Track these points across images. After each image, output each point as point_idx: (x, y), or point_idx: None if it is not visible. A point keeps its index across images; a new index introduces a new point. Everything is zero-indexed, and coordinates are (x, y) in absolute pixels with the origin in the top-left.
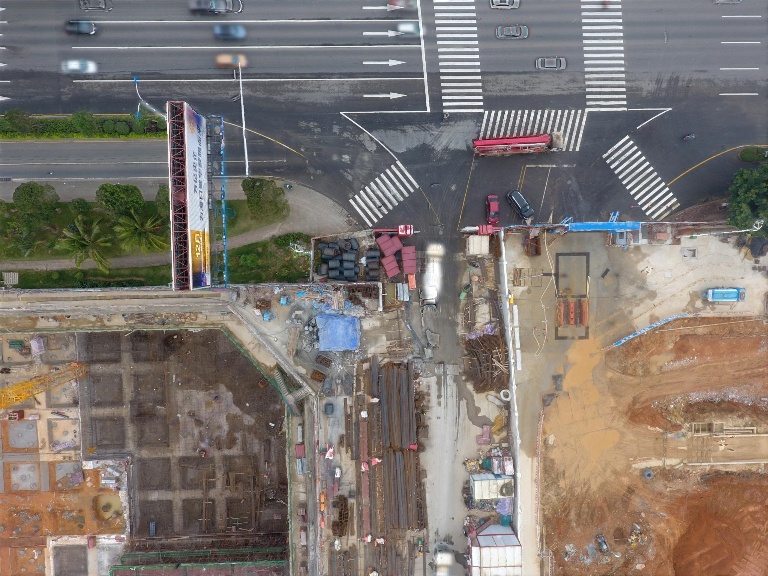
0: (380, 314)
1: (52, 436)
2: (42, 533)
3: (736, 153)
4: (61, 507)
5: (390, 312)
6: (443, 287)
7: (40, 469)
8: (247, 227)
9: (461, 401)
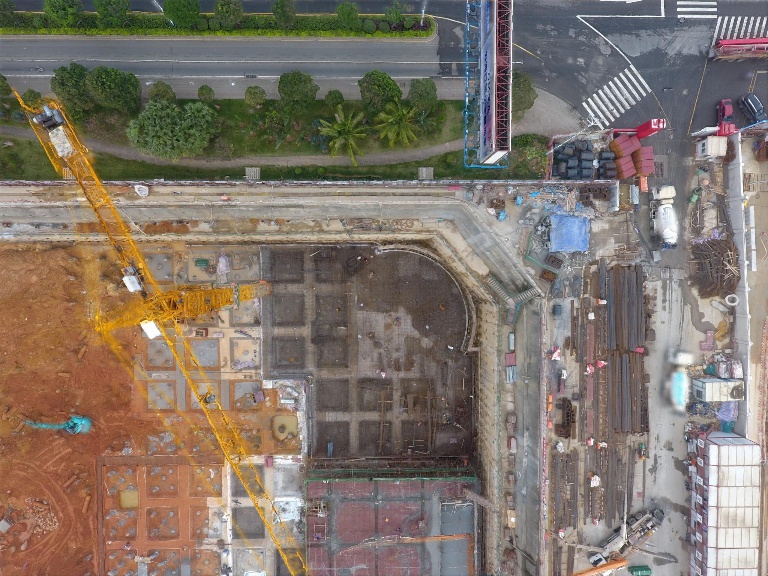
0: (610, 216)
1: (233, 355)
2: (220, 452)
3: None
4: (240, 426)
5: (619, 215)
6: None
7: (221, 387)
8: None
9: (685, 306)
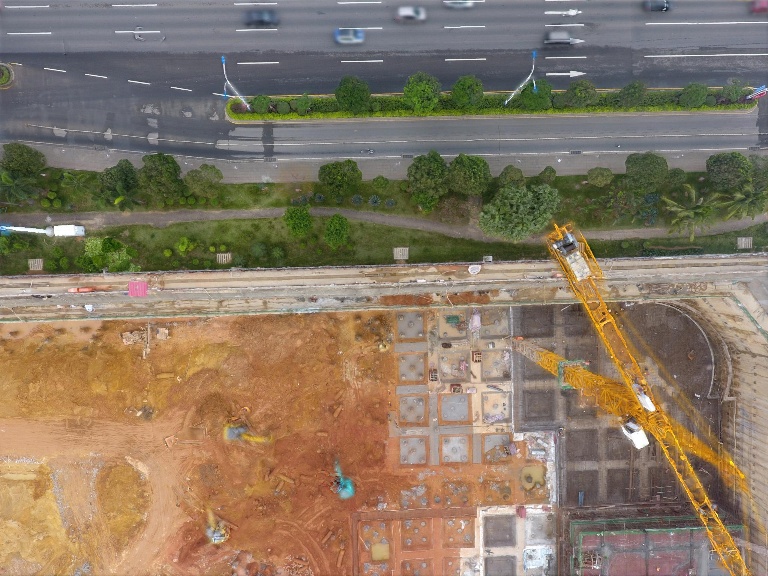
0: None
1: (483, 409)
2: (471, 504)
3: None
4: (492, 478)
5: None
6: None
7: (473, 441)
8: None
9: None
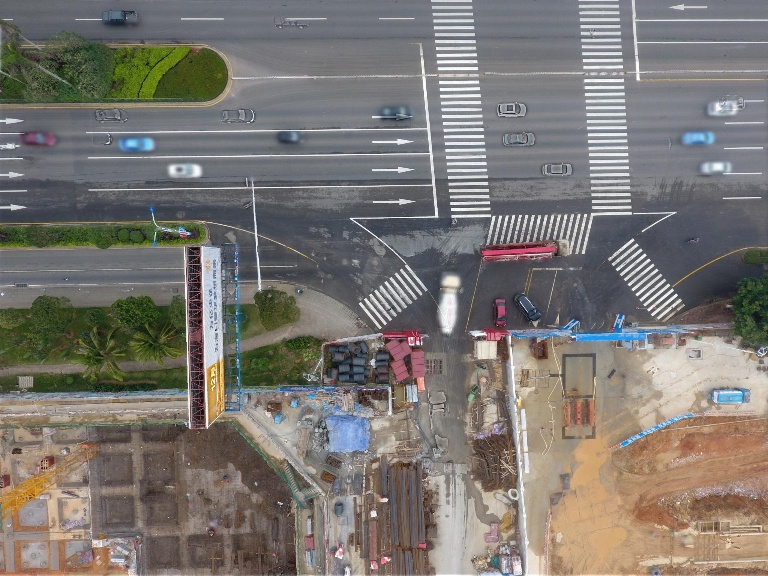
0: (389, 415)
1: (62, 515)
2: None
3: (740, 255)
4: None
5: (399, 413)
6: (451, 388)
7: (50, 548)
8: (258, 331)
9: (469, 499)
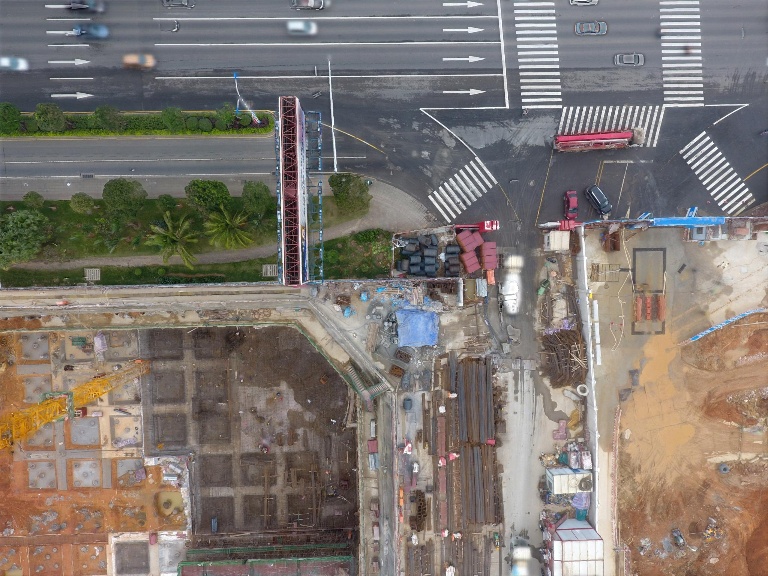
0: (458, 310)
1: (114, 433)
2: (104, 530)
3: None
4: (123, 504)
5: (468, 308)
6: (521, 283)
7: (102, 466)
8: (327, 223)
9: (538, 396)
